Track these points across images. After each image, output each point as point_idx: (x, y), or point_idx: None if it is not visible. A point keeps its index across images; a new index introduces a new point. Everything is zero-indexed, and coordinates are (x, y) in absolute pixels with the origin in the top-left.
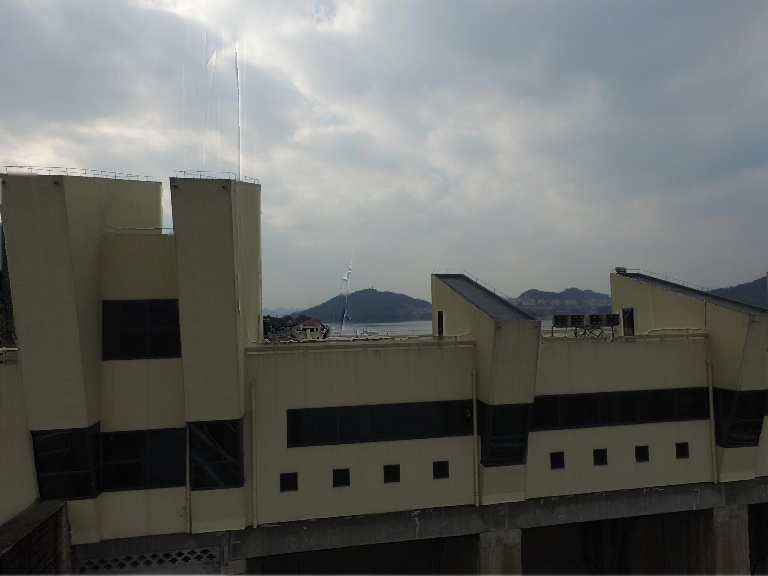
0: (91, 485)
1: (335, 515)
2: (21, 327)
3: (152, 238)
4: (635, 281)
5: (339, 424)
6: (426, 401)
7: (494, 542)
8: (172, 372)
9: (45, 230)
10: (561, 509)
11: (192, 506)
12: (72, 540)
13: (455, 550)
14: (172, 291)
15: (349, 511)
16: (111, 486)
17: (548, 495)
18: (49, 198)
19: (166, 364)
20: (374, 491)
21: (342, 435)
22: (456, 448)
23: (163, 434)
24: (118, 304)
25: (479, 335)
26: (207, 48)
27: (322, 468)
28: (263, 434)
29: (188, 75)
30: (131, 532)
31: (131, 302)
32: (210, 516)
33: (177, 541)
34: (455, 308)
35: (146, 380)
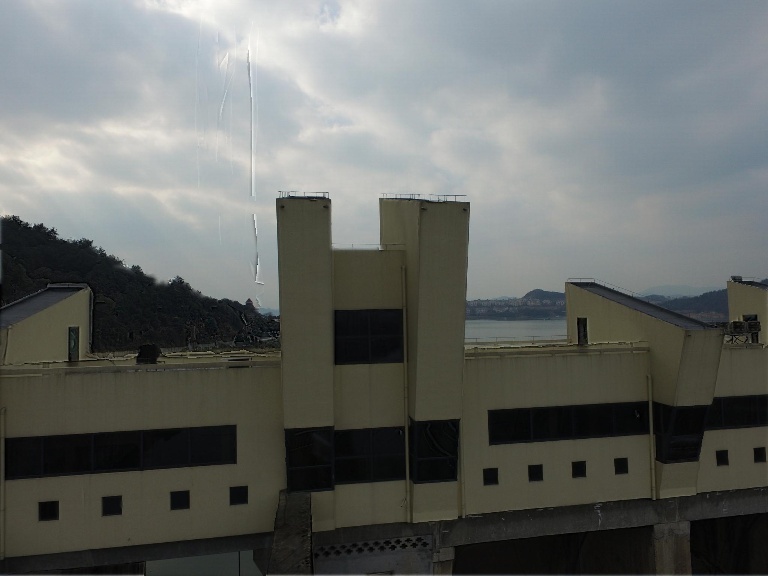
0: (331, 478)
1: (531, 507)
2: (285, 336)
3: (371, 253)
4: (760, 289)
5: (532, 424)
6: (607, 403)
7: (667, 533)
8: (390, 376)
9: (311, 249)
10: (724, 503)
11: (414, 498)
12: (312, 528)
13: (608, 541)
14: (389, 302)
15: (543, 503)
16: (341, 479)
17: (715, 490)
18: (317, 220)
19: (385, 368)
20: (564, 485)
21: (535, 434)
22: (634, 446)
23: (384, 432)
24: (343, 314)
25: (656, 342)
26: (219, 49)
27: (518, 464)
28: (468, 432)
29: (200, 76)
30: (359, 521)
31: (354, 312)
32: (428, 507)
33: (396, 530)
34: (612, 316)
35: (369, 383)
